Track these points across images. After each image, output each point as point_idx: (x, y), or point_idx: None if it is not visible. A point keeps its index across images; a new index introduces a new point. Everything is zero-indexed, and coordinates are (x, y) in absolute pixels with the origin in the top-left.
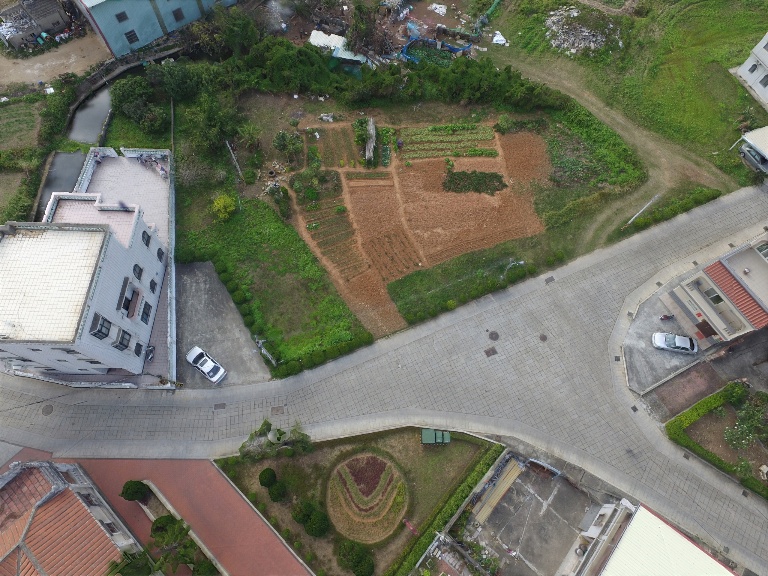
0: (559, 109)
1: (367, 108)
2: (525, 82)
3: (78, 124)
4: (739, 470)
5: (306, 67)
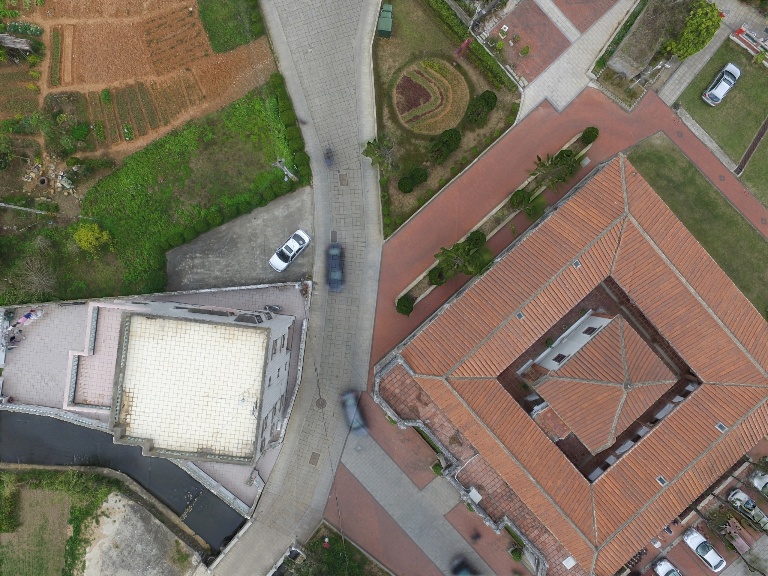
0: None
1: None
2: None
3: None
4: None
5: None
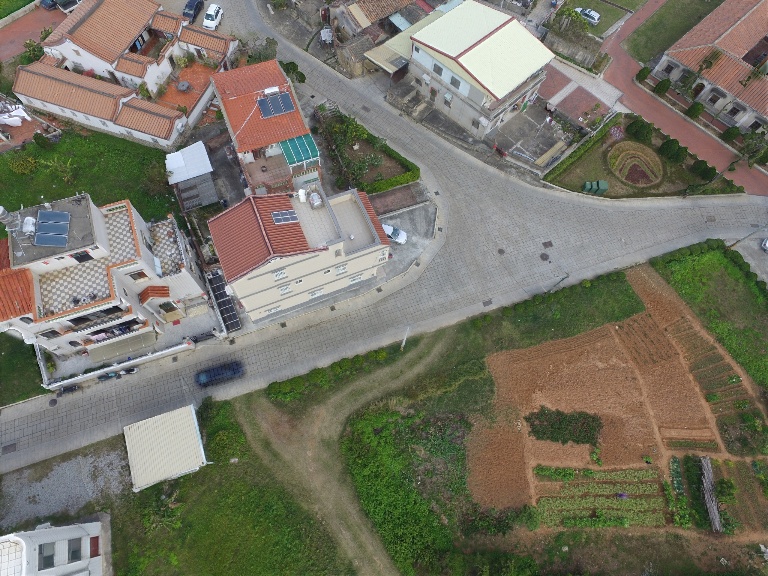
0: (442, 552)
1: (719, 572)
2: None
3: None
4: (384, 142)
5: None
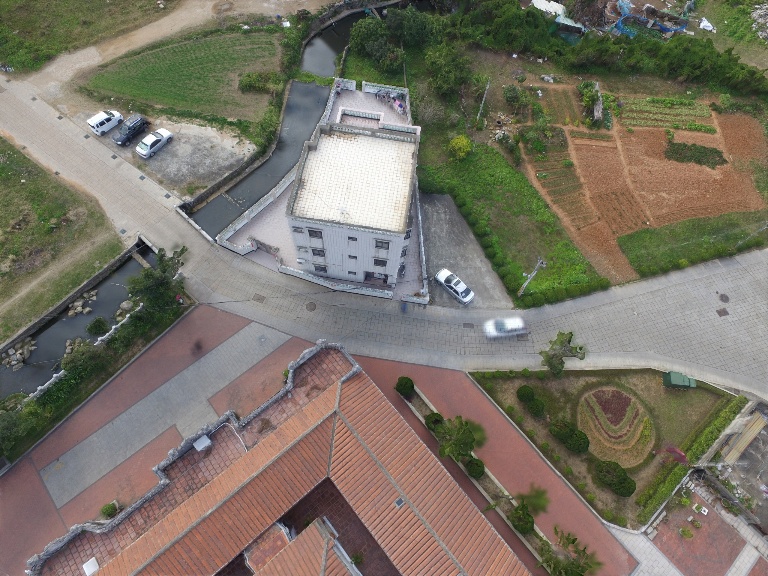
0: None
1: (585, 74)
2: (746, 66)
3: (309, 58)
4: None
5: (530, 28)
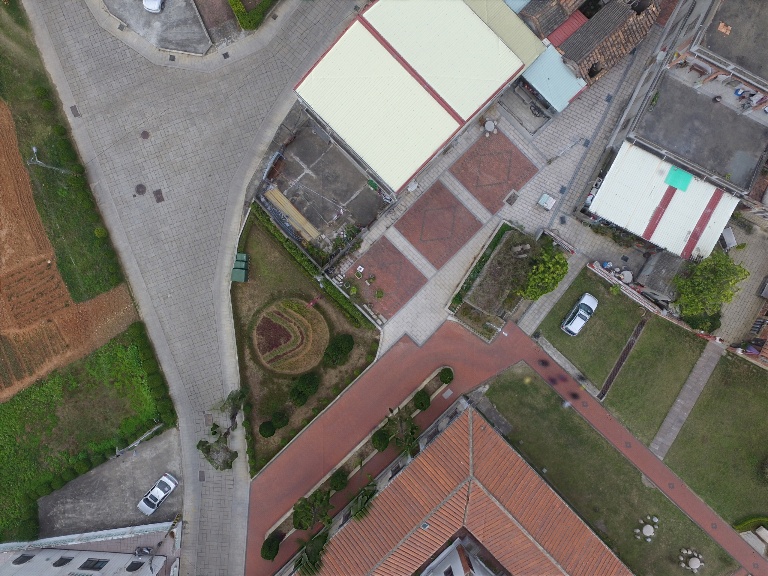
0: None
1: None
2: None
3: None
4: None
5: None
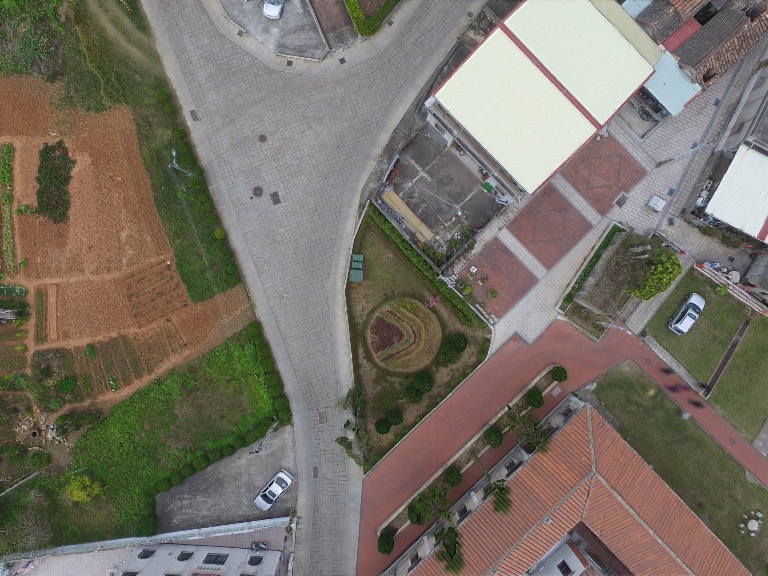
0: None
1: None
2: None
3: None
4: None
5: None
